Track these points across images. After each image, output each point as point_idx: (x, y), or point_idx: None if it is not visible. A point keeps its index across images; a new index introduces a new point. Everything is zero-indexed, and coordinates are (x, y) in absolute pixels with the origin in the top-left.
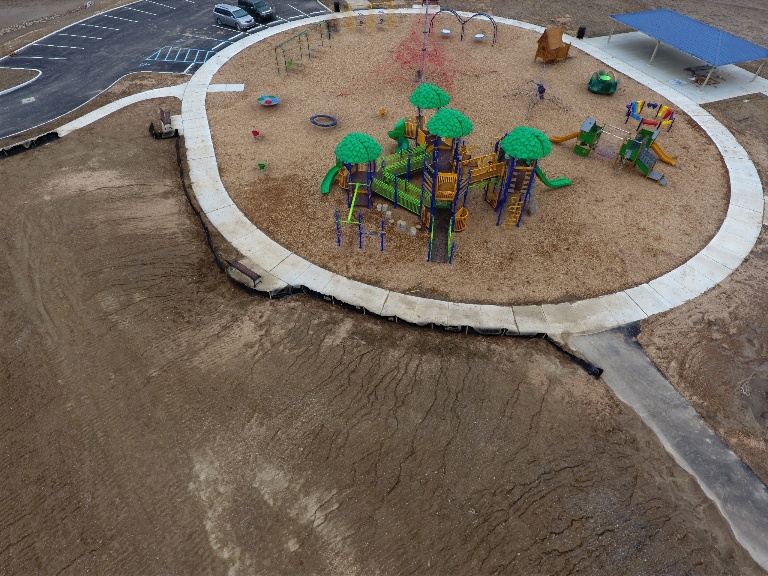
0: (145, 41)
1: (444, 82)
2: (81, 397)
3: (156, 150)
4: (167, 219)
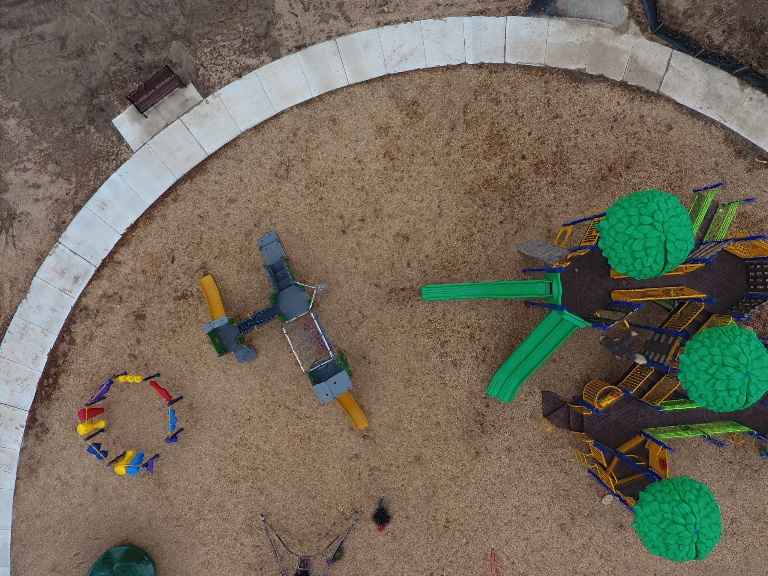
0: None
1: None
2: None
3: None
4: None
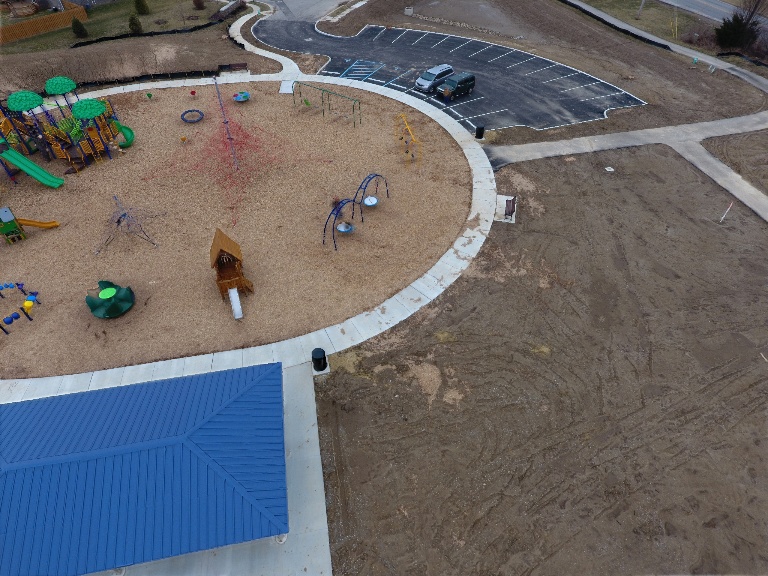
0: (400, 57)
1: (230, 183)
2: (3, 56)
3: (201, 69)
4: (119, 74)
